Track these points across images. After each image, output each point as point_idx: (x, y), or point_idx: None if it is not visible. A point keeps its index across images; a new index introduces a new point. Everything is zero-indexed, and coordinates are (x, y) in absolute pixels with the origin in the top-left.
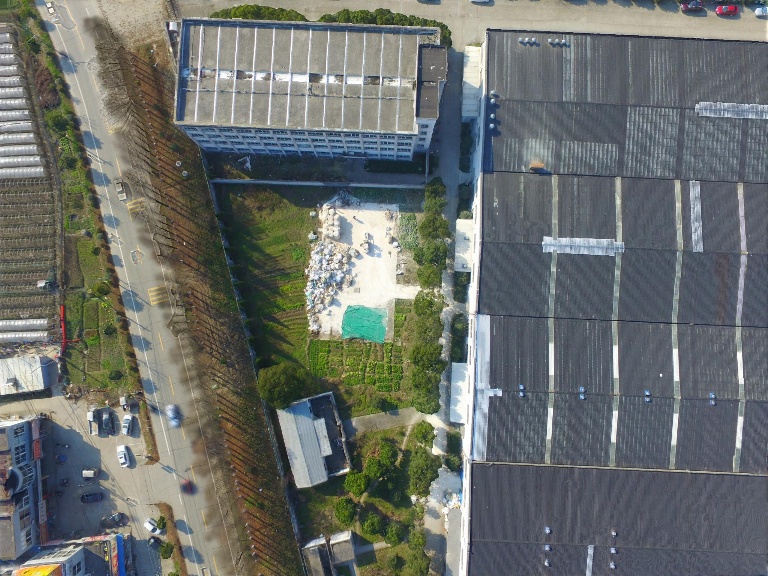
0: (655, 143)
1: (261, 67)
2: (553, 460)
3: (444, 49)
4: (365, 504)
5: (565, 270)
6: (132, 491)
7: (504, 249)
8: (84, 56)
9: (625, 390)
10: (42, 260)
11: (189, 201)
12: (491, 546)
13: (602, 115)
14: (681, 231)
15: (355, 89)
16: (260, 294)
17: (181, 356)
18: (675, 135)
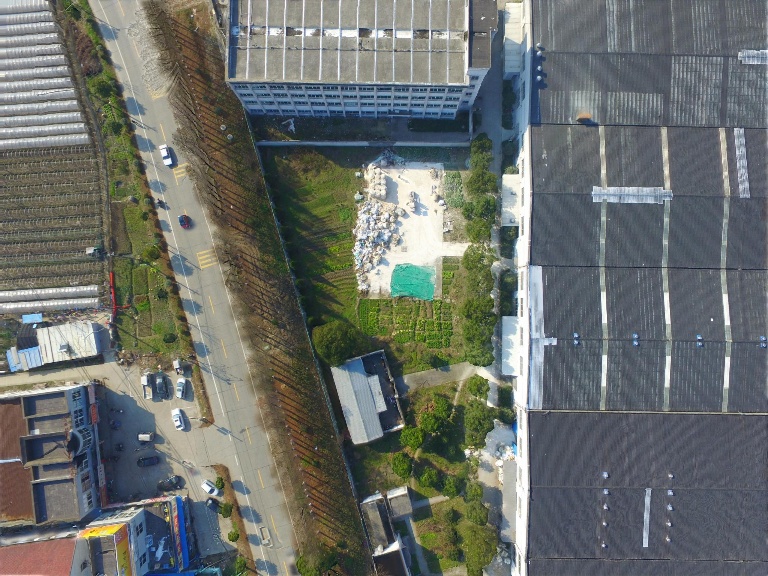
0: (699, 92)
1: (310, 23)
2: (608, 406)
3: None
4: (419, 459)
5: (615, 219)
6: (188, 454)
7: (554, 200)
8: (124, 22)
9: (677, 335)
10: (89, 227)
11: (235, 164)
12: (550, 492)
13: (647, 65)
14: (728, 178)
15: (405, 43)
16: (308, 255)
17: (232, 319)
18: (719, 83)
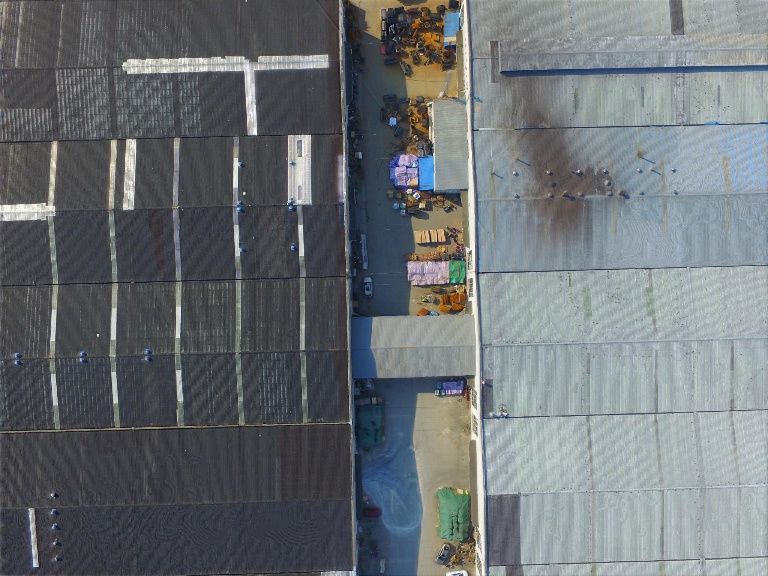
0: (87, 104)
1: None
2: None
3: None
4: None
5: None
6: None
7: None
8: None
9: (61, 352)
10: None
11: None
12: None
13: (31, 80)
14: (113, 190)
15: None
16: None
17: None
18: (106, 95)
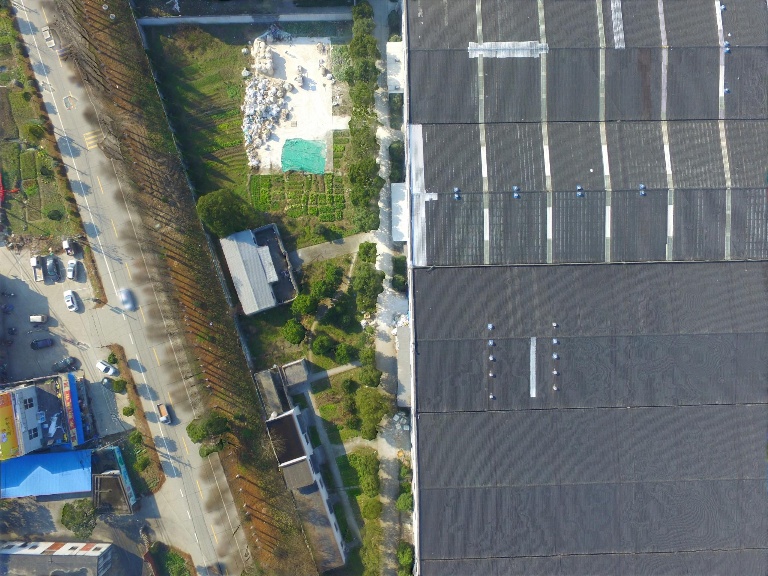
0: None
1: None
2: (492, 260)
3: None
4: (316, 332)
5: (492, 74)
6: (82, 335)
7: (431, 57)
8: None
9: (557, 186)
10: None
11: (119, 43)
12: (436, 345)
13: None
14: (603, 30)
15: None
16: (197, 133)
17: (122, 198)
18: None
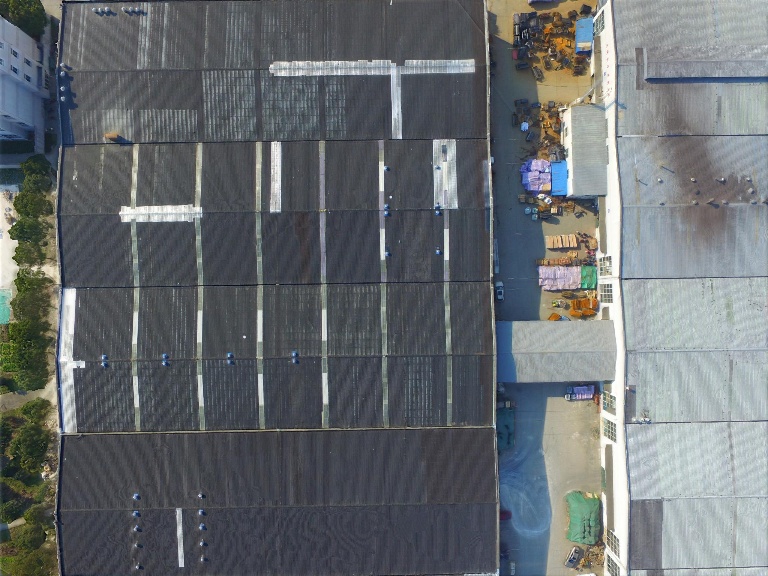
0: (233, 106)
1: None
2: (144, 427)
3: None
4: None
5: (146, 239)
6: None
7: (82, 221)
8: None
9: (208, 354)
10: None
11: None
12: (80, 515)
13: (177, 81)
14: (260, 192)
15: None
16: None
17: None
18: (252, 97)
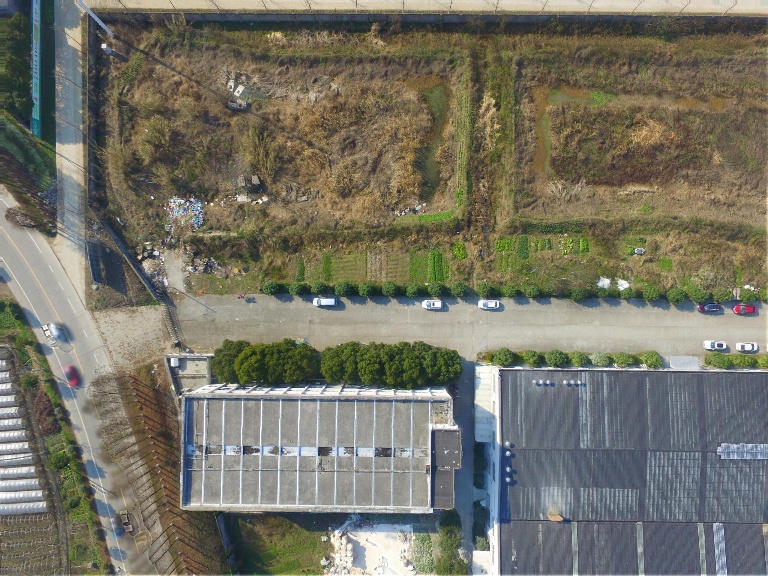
0: (677, 487)
1: (268, 442)
2: None
3: (458, 432)
4: None
5: None
6: None
7: None
8: (83, 380)
9: None
10: None
11: (197, 532)
12: None
13: (621, 461)
14: None
15: (366, 462)
16: None
17: None
18: (697, 478)
